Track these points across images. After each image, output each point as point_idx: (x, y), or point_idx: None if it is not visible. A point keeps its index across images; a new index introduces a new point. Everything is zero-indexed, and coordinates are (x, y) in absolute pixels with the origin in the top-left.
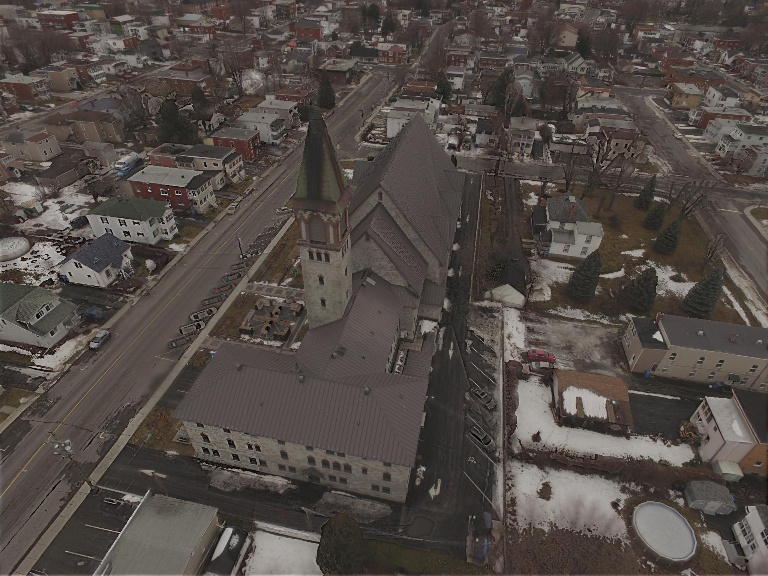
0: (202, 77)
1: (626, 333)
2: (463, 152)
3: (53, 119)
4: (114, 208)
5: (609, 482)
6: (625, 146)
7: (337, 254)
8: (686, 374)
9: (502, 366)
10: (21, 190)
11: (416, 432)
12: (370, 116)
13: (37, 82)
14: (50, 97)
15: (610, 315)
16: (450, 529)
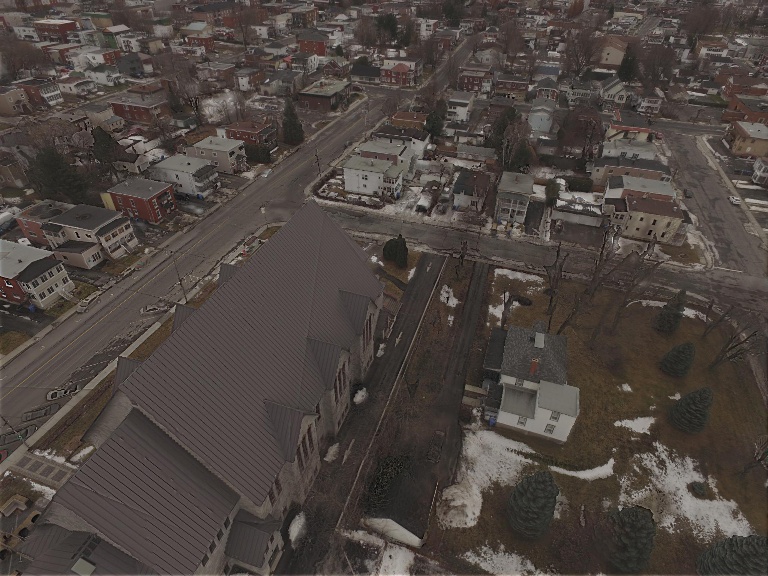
0: (156, 103)
1: None
2: (434, 217)
3: None
4: None
5: None
6: (653, 222)
7: None
8: None
9: None
10: None
11: None
12: (339, 157)
13: None
14: None
15: (569, 575)
16: None
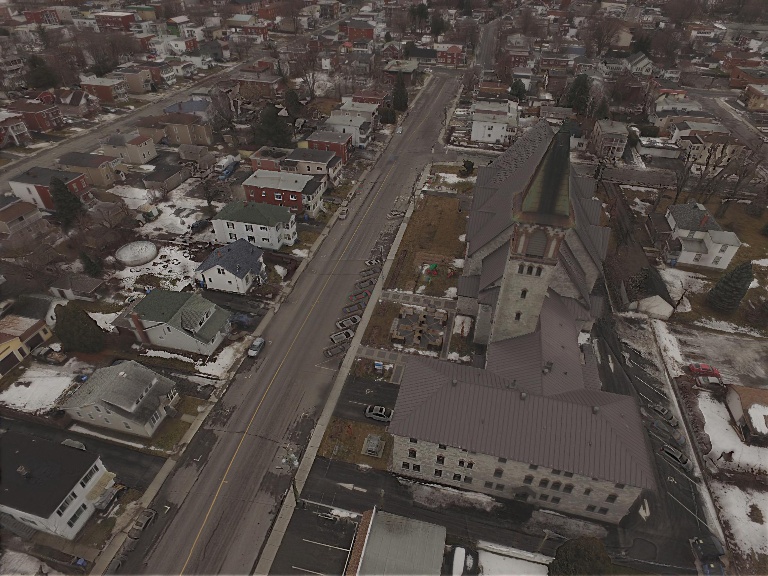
0: (275, 79)
1: None
2: None
3: (146, 122)
4: (241, 213)
5: None
6: None
7: (551, 268)
8: None
9: (669, 381)
10: (130, 193)
11: (645, 453)
12: (446, 118)
13: (117, 84)
14: (128, 99)
15: (758, 328)
16: (674, 553)
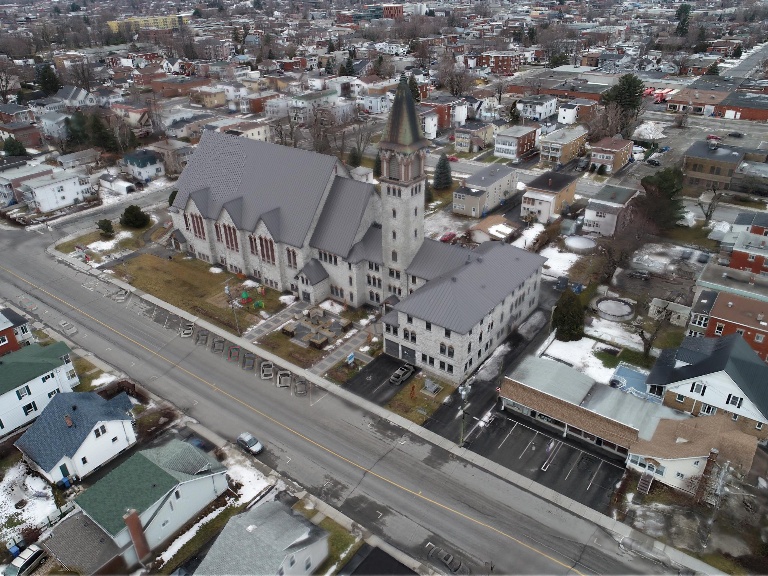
0: None
1: (455, 204)
2: (147, 189)
3: None
4: None
5: (547, 249)
6: (258, 134)
7: None
8: (493, 204)
9: None
10: None
11: None
12: None
13: None
14: None
15: (426, 209)
16: (560, 296)
